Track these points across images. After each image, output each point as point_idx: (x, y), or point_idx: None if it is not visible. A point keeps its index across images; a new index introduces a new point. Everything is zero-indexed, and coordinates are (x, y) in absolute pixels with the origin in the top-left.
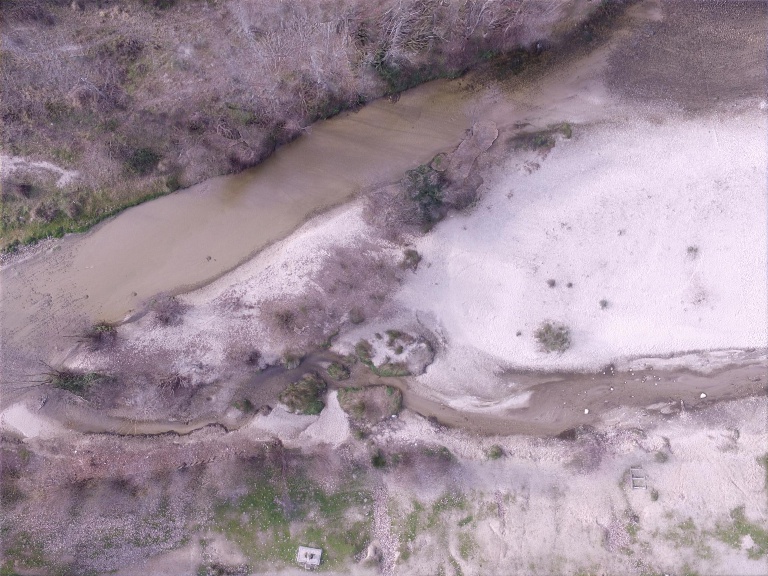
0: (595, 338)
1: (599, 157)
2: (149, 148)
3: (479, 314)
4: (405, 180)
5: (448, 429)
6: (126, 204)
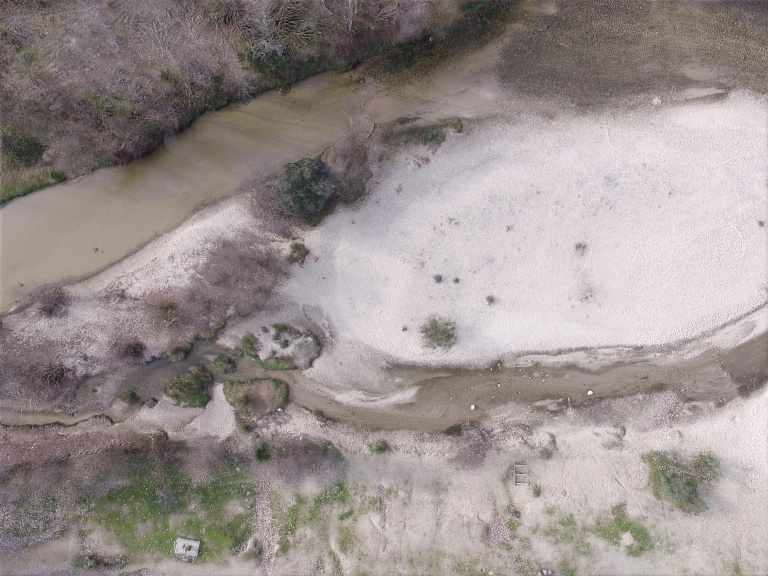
0: (482, 334)
1: (489, 152)
2: (34, 138)
3: (366, 309)
4: (278, 173)
5: (334, 423)
6: (12, 194)
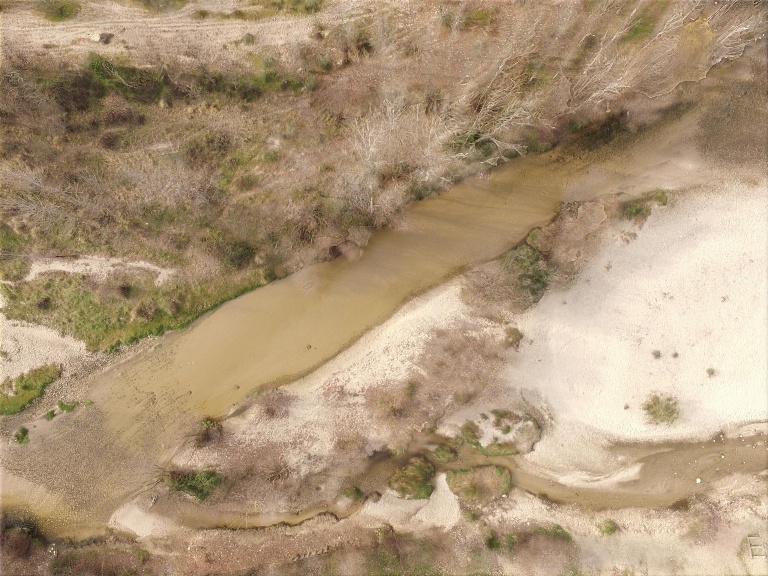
0: (704, 407)
1: (697, 223)
2: (245, 242)
3: (585, 389)
4: (515, 268)
5: (559, 506)
6: (224, 298)
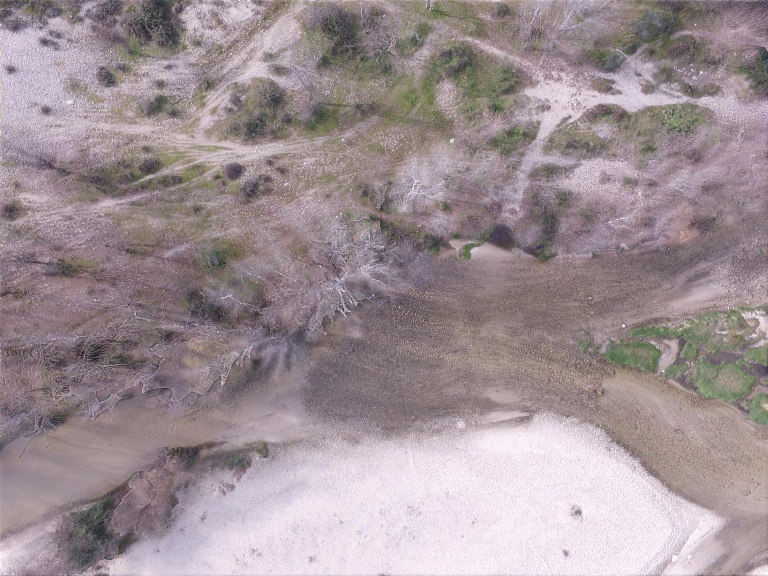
0: None
1: (294, 478)
2: None
3: None
4: None
5: None
6: None
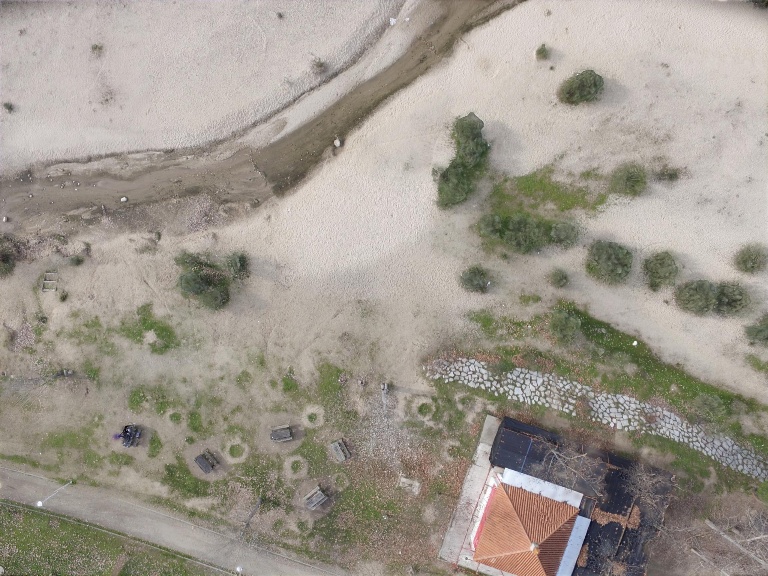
0: (5, 143)
1: None
2: None
3: None
4: None
5: None
6: None
